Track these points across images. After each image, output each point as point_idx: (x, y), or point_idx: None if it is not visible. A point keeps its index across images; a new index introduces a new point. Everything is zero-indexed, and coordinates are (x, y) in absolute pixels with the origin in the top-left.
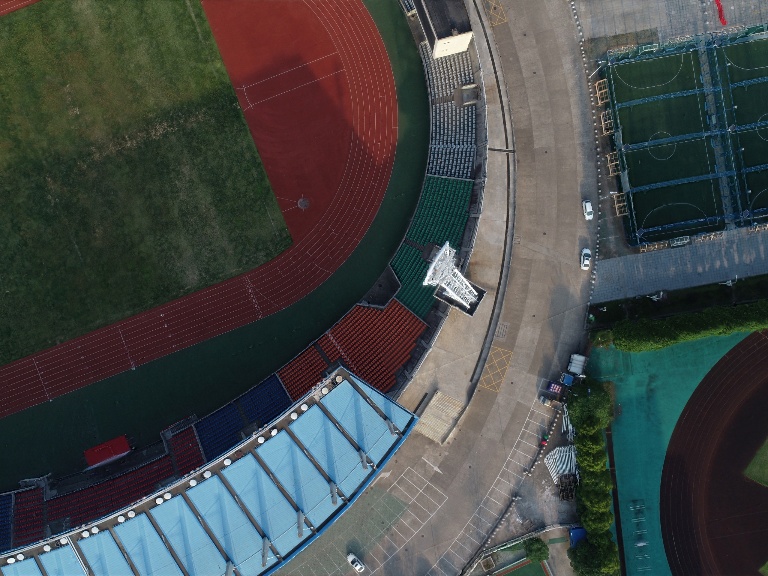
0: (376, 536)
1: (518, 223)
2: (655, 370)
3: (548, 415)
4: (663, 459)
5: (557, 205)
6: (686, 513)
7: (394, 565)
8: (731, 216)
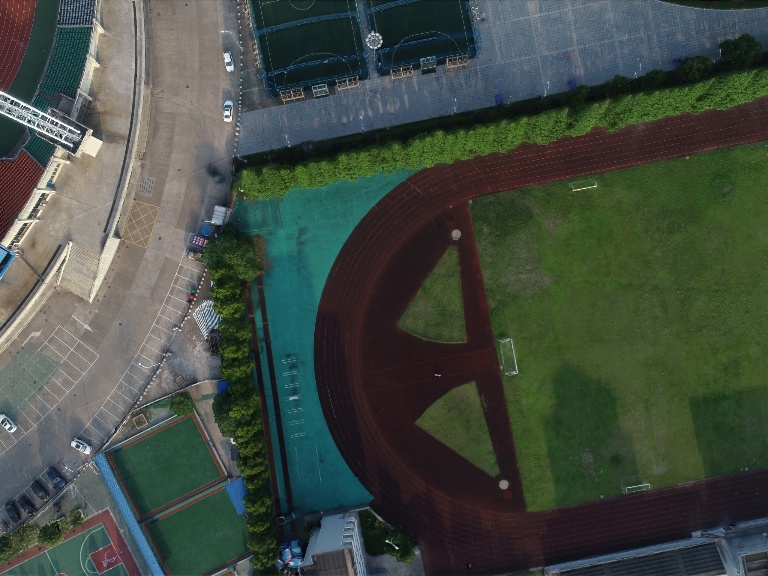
0: (28, 396)
1: (161, 77)
2: (305, 223)
3: (197, 270)
4: (316, 312)
5: (199, 58)
6: (341, 366)
7: (47, 425)
8: (373, 65)
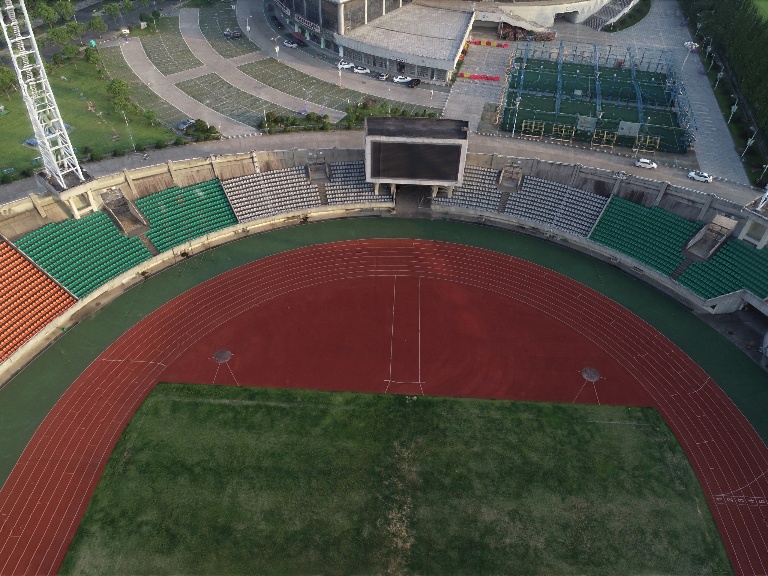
0: None
1: None
2: None
3: None
4: None
5: None
6: None
7: None
8: None
